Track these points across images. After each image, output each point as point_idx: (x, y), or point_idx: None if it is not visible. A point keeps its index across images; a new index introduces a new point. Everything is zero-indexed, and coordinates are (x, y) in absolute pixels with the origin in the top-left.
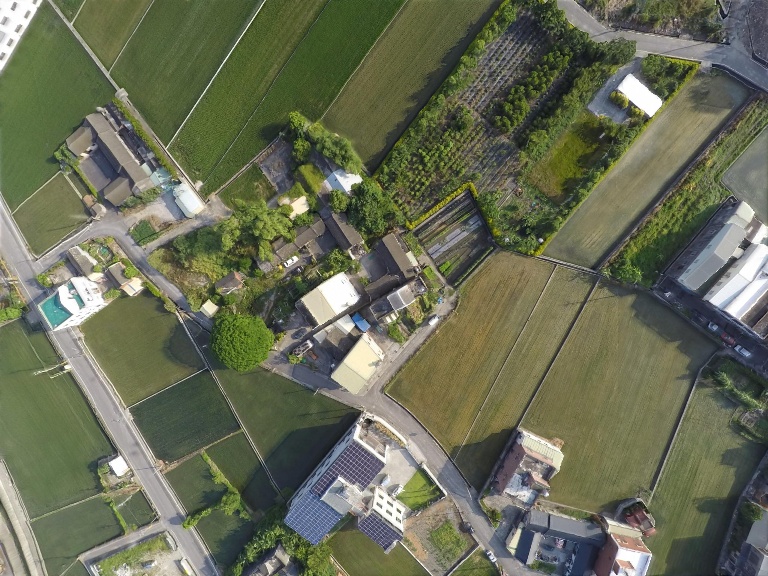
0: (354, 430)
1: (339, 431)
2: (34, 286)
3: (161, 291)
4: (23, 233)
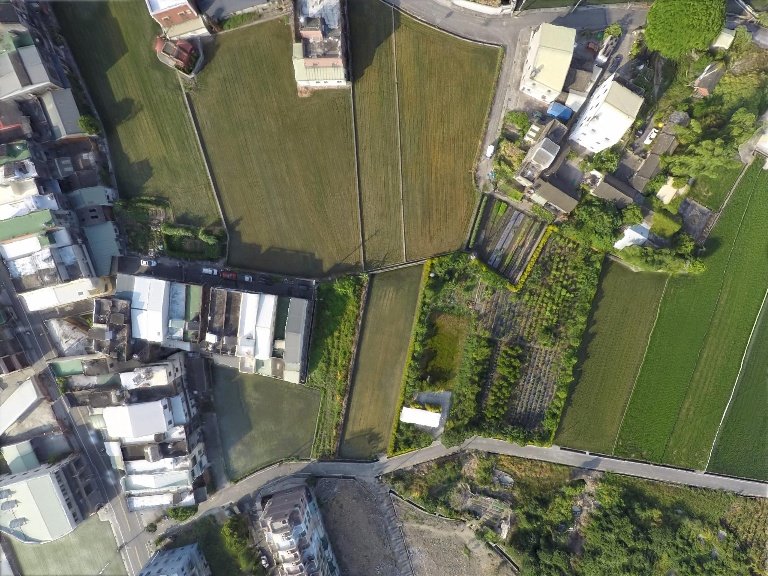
0: None
1: None
2: None
3: None
4: None
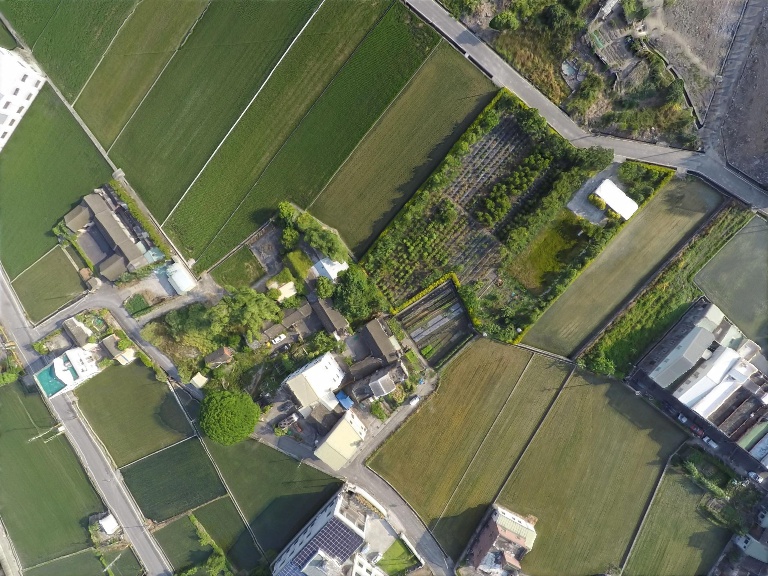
0: (335, 502)
1: (322, 499)
2: (31, 351)
3: (153, 361)
4: (21, 301)
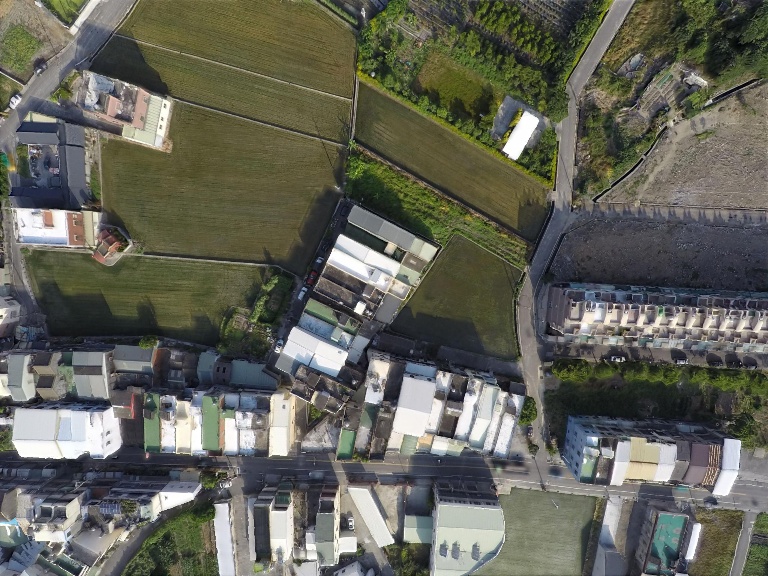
0: None
1: None
2: None
3: None
4: None
